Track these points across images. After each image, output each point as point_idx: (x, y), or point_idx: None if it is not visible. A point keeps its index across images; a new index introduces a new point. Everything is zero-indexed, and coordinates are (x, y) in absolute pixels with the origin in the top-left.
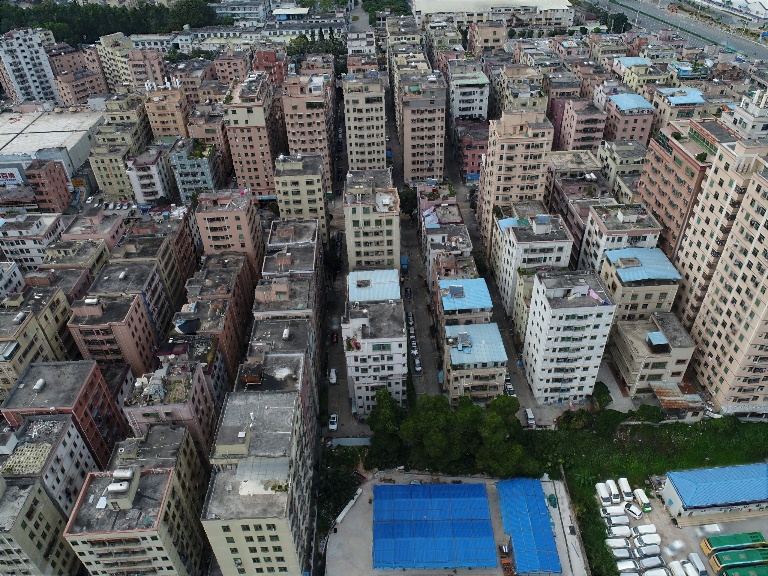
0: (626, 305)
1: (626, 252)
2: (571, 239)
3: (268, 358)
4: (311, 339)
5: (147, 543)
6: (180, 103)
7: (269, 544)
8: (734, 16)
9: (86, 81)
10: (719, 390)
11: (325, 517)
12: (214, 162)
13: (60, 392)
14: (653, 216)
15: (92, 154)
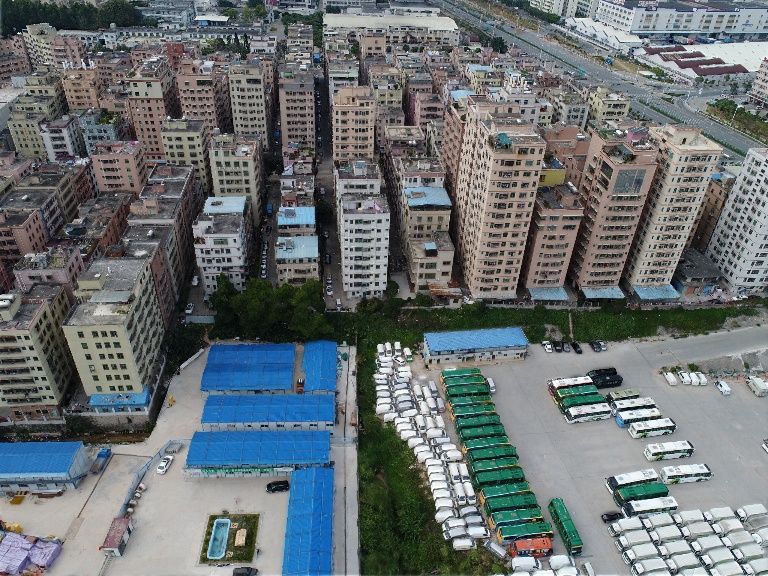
0: (415, 226)
1: (418, 189)
2: (379, 179)
3: (132, 245)
4: (170, 239)
5: (22, 342)
6: (94, 81)
7: (114, 351)
8: (596, 47)
9: (11, 63)
10: (471, 283)
11: (172, 365)
12: (120, 130)
13: None
14: (442, 165)
15: (11, 119)
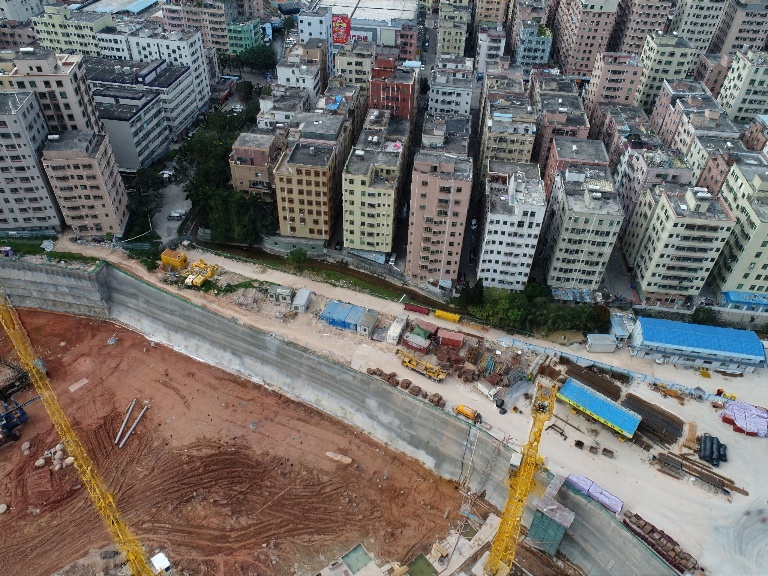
0: None
1: None
2: None
3: None
4: None
5: (720, 233)
6: None
7: None
8: None
9: None
10: None
11: None
12: None
13: (590, 155)
14: None
15: (440, 26)
